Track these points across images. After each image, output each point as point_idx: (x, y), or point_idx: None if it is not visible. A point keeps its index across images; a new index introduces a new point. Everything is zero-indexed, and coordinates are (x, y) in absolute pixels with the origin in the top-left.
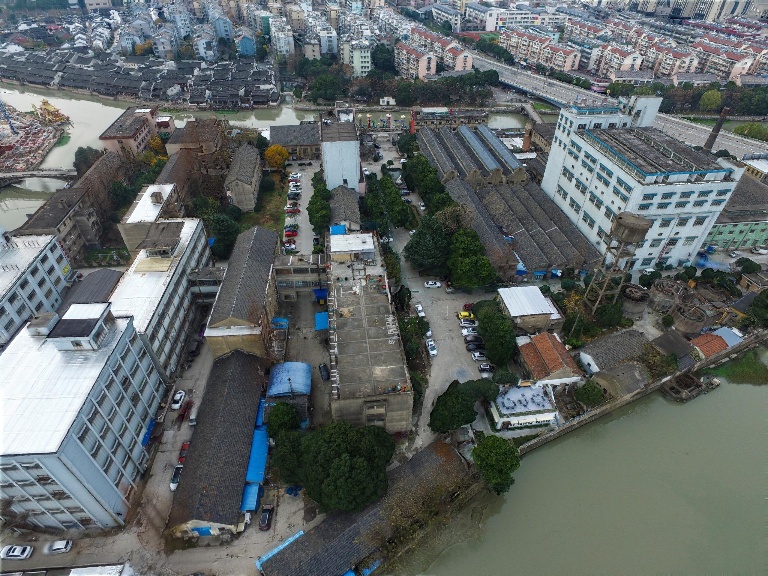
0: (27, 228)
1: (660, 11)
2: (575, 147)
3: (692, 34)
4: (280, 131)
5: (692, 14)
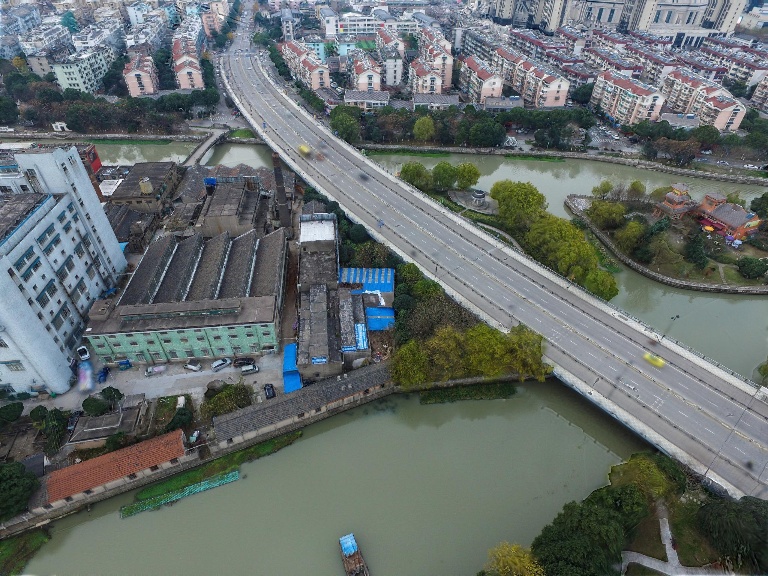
0: None
1: (521, 18)
2: None
3: (493, 46)
4: None
5: (540, 22)
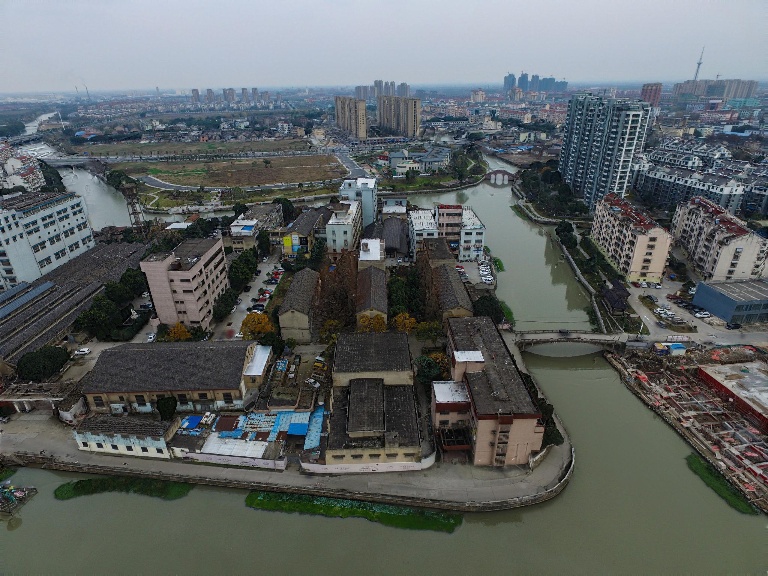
0: (440, 238)
1: None
2: (31, 225)
3: None
4: (235, 344)
5: None
